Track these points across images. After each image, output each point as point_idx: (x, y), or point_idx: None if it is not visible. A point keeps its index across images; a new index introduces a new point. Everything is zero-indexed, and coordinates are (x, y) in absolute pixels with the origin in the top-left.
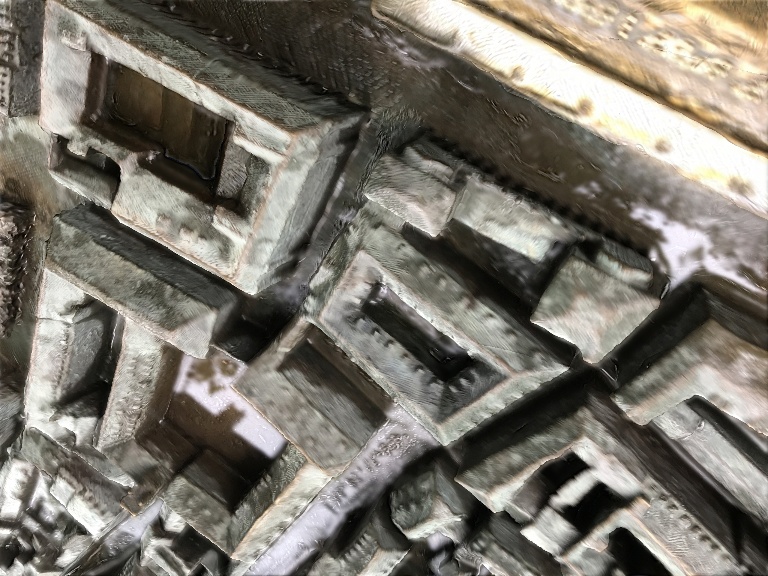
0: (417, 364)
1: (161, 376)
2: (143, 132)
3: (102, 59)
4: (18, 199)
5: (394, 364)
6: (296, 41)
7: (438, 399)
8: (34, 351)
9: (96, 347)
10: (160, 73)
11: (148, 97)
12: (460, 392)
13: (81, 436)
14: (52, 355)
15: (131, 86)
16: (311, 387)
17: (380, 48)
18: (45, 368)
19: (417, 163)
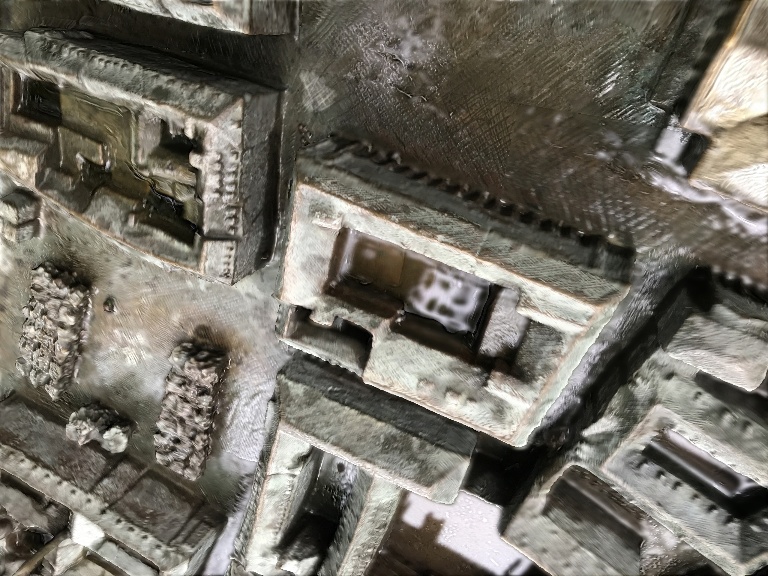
0: (709, 504)
1: None
2: (382, 291)
3: (346, 230)
4: (210, 345)
5: (685, 507)
6: (544, 186)
7: (737, 539)
8: (261, 505)
9: (307, 485)
10: (426, 247)
11: (387, 256)
12: (766, 532)
13: (301, 575)
14: (276, 505)
15: (368, 247)
16: (574, 525)
17: (645, 189)
18: (269, 518)
19: (732, 322)
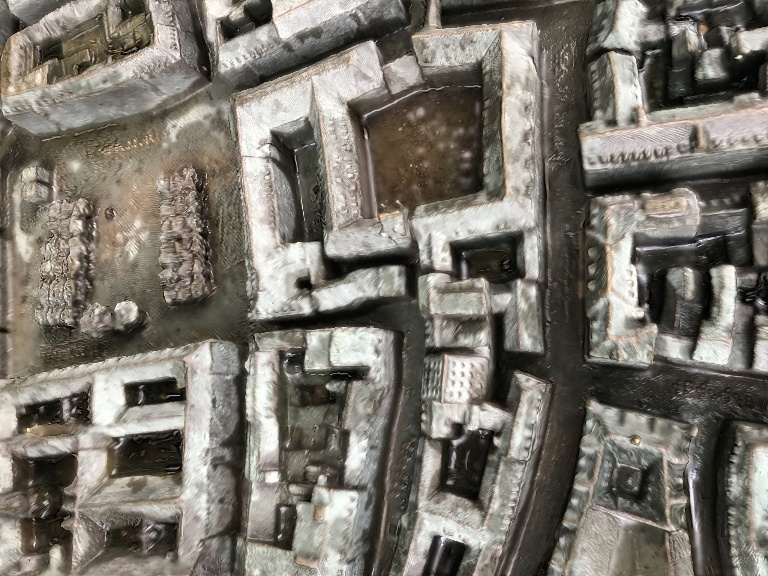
0: None
1: (357, 149)
2: None
3: None
4: None
5: None
6: None
7: None
8: (247, 189)
9: (293, 210)
10: None
11: None
12: None
13: (313, 270)
14: (262, 195)
15: None
16: None
17: None
18: (260, 209)
19: None
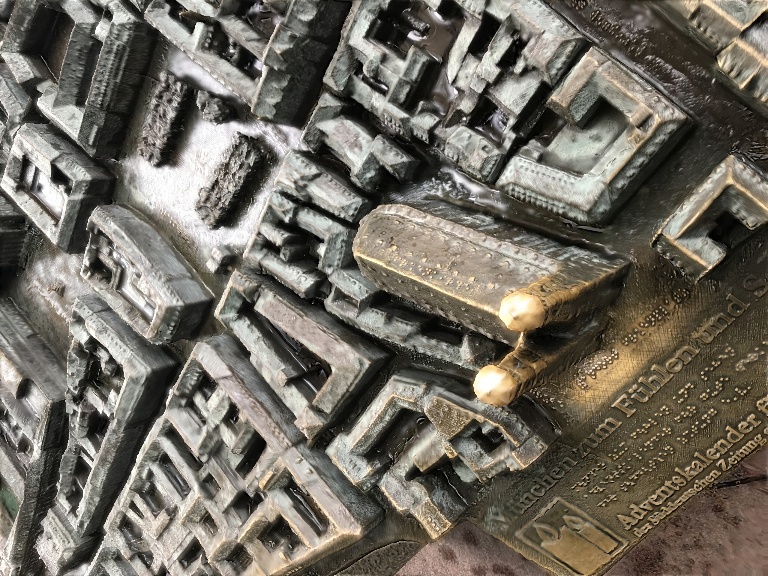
0: None
1: None
2: None
3: None
4: None
5: None
6: None
7: None
8: (92, 83)
9: None
10: None
11: None
12: None
13: None
14: None
15: None
16: None
17: None
18: None
19: None
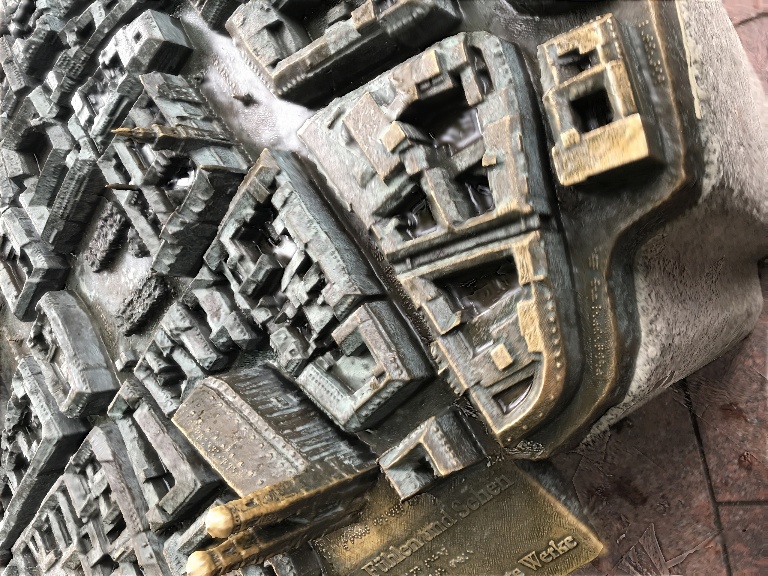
0: None
1: None
2: None
3: None
4: None
5: None
6: None
7: None
8: None
9: None
10: None
11: None
12: None
13: None
14: None
15: None
16: None
17: None
18: None
19: None
